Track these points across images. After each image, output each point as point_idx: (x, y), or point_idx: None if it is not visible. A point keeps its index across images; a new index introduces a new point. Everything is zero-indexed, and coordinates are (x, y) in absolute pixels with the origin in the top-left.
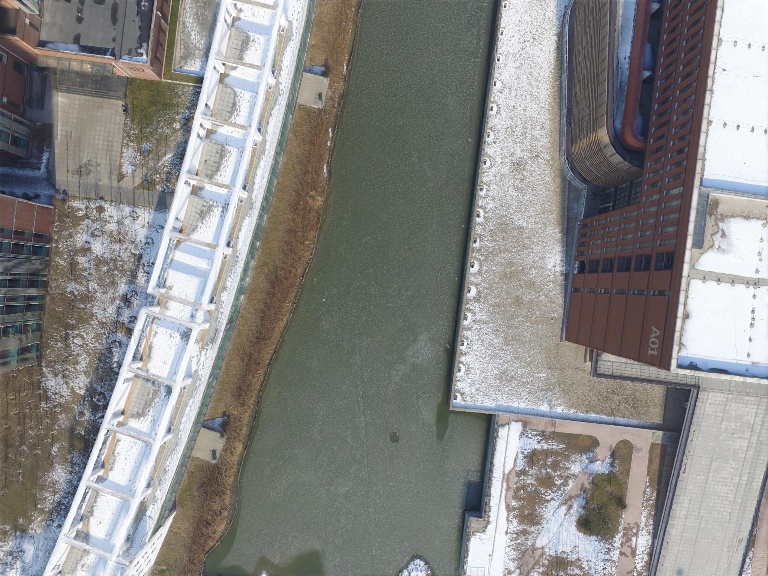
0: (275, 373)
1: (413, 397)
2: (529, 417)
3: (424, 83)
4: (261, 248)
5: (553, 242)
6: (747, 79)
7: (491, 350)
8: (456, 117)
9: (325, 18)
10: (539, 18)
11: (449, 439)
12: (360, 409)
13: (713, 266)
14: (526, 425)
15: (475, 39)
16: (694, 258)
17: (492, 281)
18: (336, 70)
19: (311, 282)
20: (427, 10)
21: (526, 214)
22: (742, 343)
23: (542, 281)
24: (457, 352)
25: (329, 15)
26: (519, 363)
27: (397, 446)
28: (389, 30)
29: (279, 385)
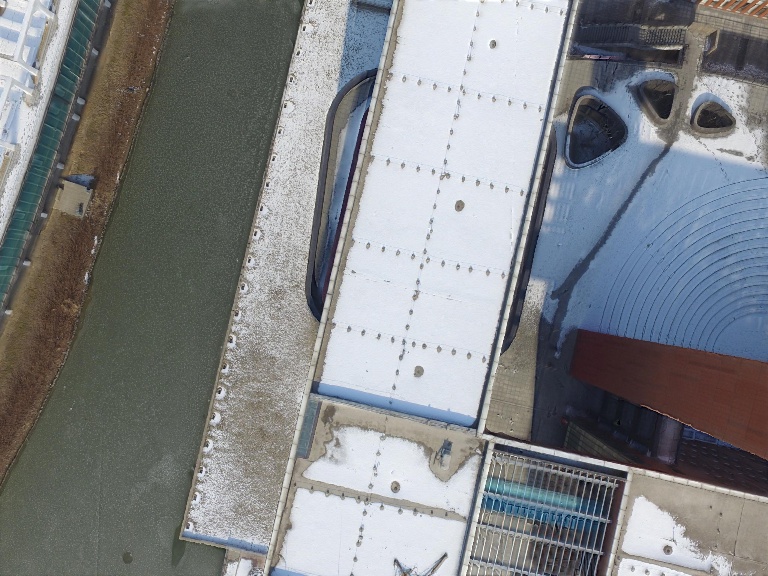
0: (13, 478)
1: (151, 518)
2: (260, 556)
3: (196, 199)
4: (6, 353)
5: (305, 376)
6: (377, 283)
7: (230, 481)
8: (225, 236)
9: (98, 128)
10: (313, 147)
11: (184, 566)
12: (96, 525)
13: (323, 476)
14: (256, 564)
15: (253, 160)
16: (303, 466)
17: (238, 409)
18: (107, 179)
19: (60, 389)
20: (207, 127)
21: (280, 344)
22: (346, 562)
23: (290, 415)
24: (193, 480)
25: (103, 125)
26: (258, 497)
27: (129, 567)
28: (167, 143)
29: (16, 491)
